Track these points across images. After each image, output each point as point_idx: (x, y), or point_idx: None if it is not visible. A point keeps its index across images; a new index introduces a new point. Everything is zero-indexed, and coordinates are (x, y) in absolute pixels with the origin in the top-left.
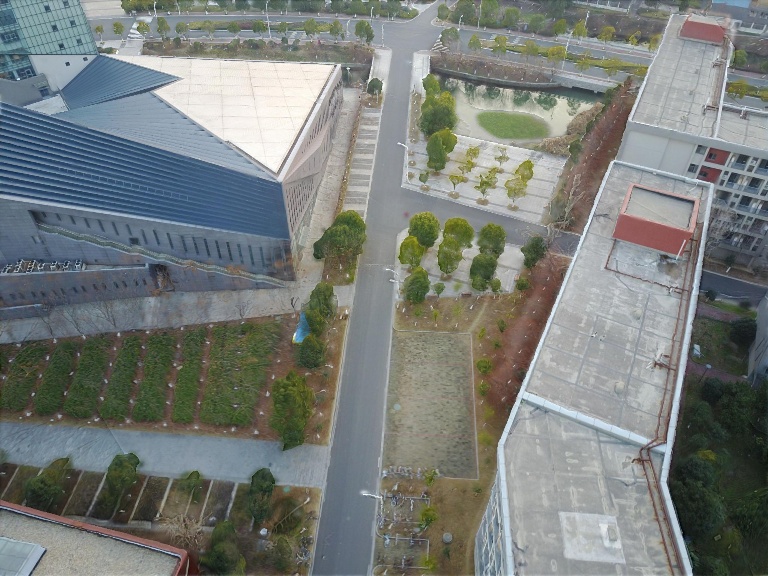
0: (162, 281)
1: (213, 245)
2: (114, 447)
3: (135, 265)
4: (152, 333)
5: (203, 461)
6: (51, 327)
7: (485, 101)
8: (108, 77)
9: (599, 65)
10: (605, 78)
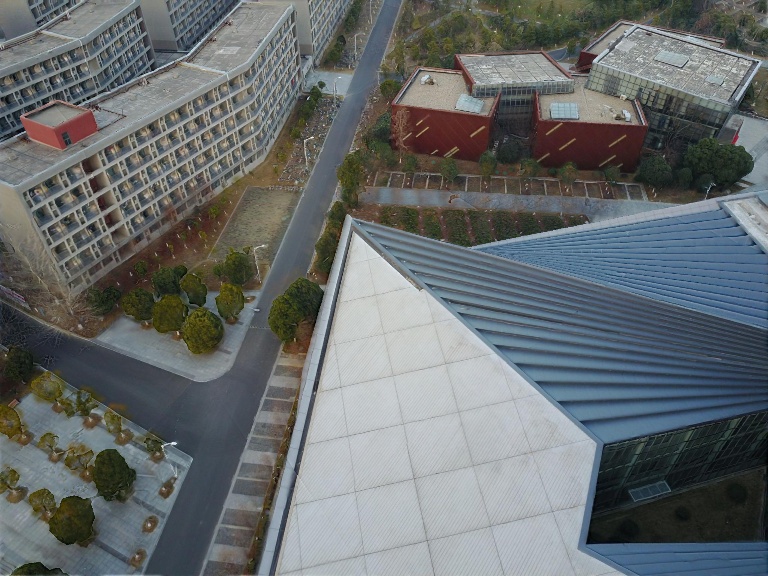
0: None
1: None
2: (468, 200)
3: None
4: None
5: (410, 195)
6: None
7: None
8: None
9: None
10: None
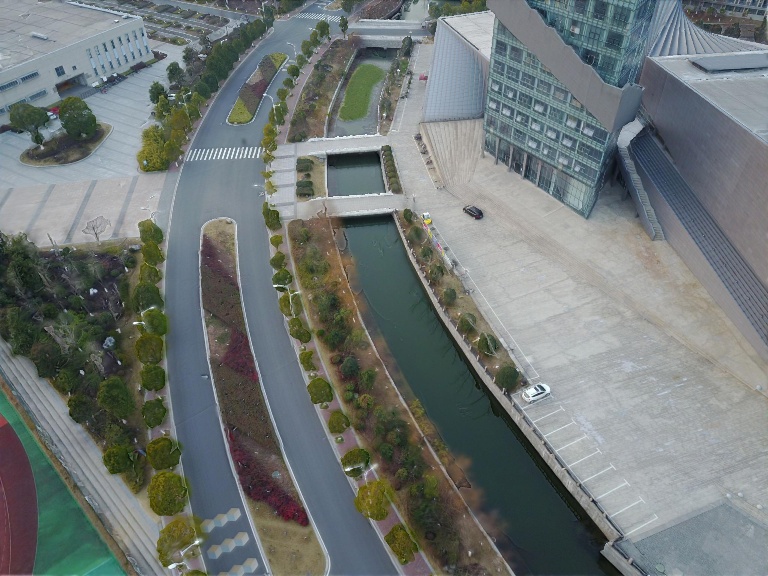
0: None
1: None
2: None
3: None
4: None
5: None
6: None
7: None
8: None
9: None
10: None
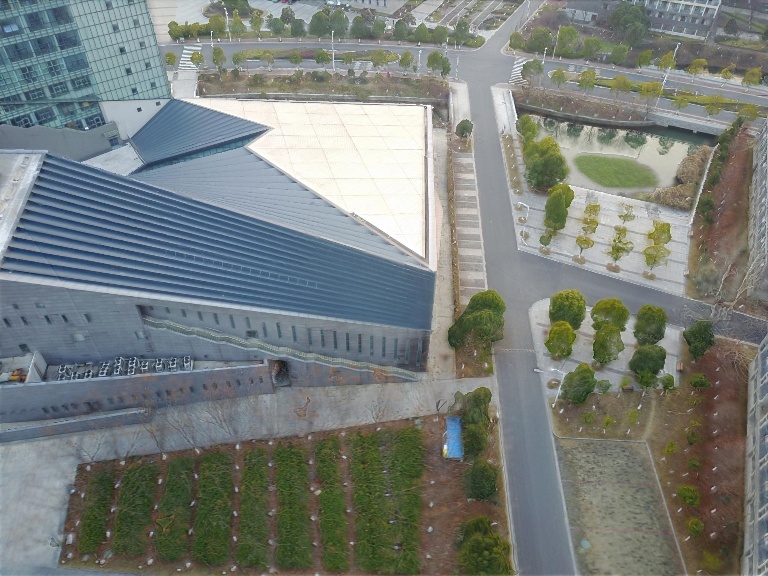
0: (276, 375)
1: (343, 337)
2: None
3: (251, 361)
4: (276, 444)
5: None
6: (156, 437)
7: (570, 139)
8: (185, 124)
9: (694, 101)
10: (704, 116)
